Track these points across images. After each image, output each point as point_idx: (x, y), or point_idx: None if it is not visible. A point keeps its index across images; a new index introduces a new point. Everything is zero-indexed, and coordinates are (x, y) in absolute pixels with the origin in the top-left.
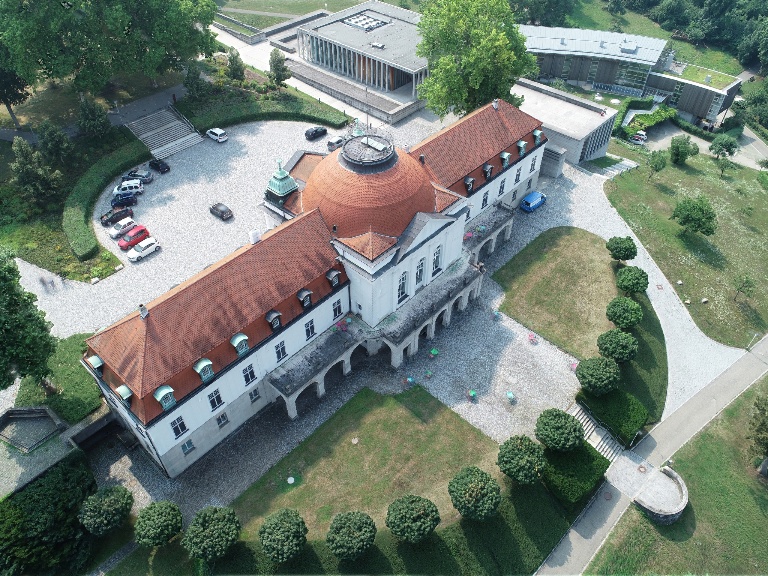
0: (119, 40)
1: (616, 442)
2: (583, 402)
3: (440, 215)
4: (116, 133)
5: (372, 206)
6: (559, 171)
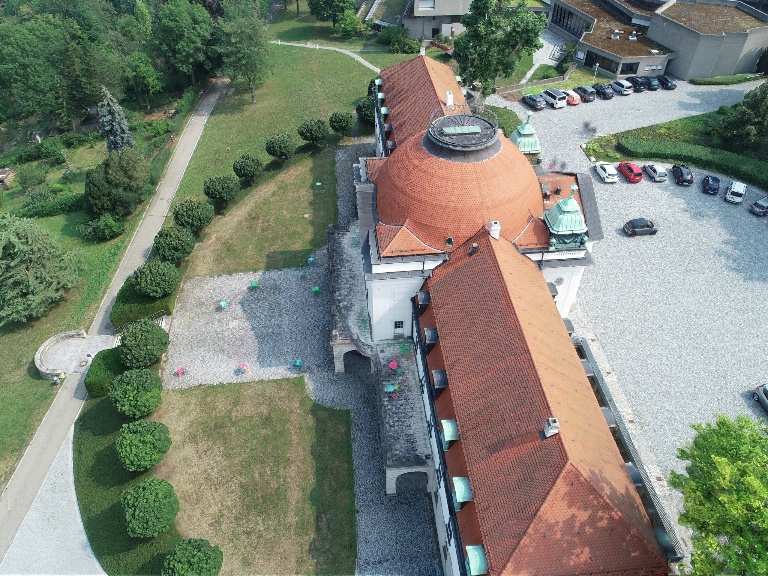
0: None
1: None
2: None
3: (368, 221)
4: None
5: None
6: None
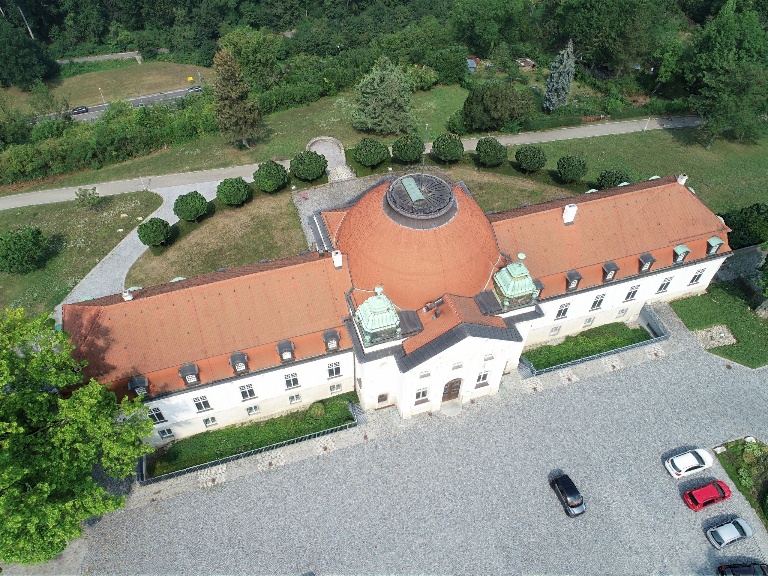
0: None
1: None
2: None
3: None
4: None
5: None
6: None
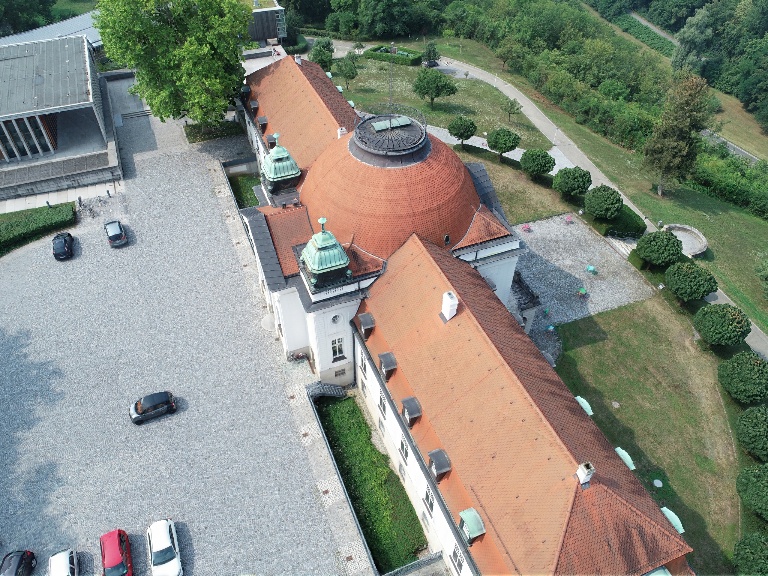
0: None
1: (636, 240)
2: (611, 231)
3: None
4: None
5: (461, 184)
6: None
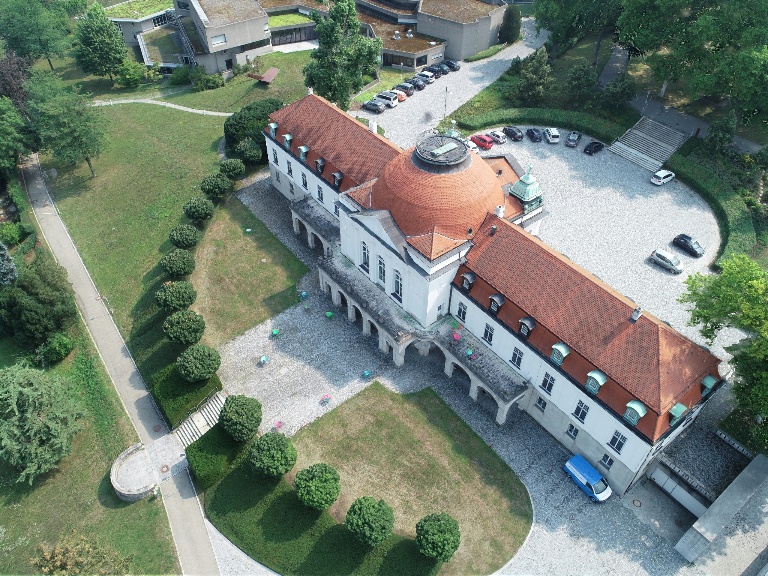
0: (711, 53)
1: None
2: None
3: (399, 239)
4: (627, 113)
5: None
6: (685, 549)
